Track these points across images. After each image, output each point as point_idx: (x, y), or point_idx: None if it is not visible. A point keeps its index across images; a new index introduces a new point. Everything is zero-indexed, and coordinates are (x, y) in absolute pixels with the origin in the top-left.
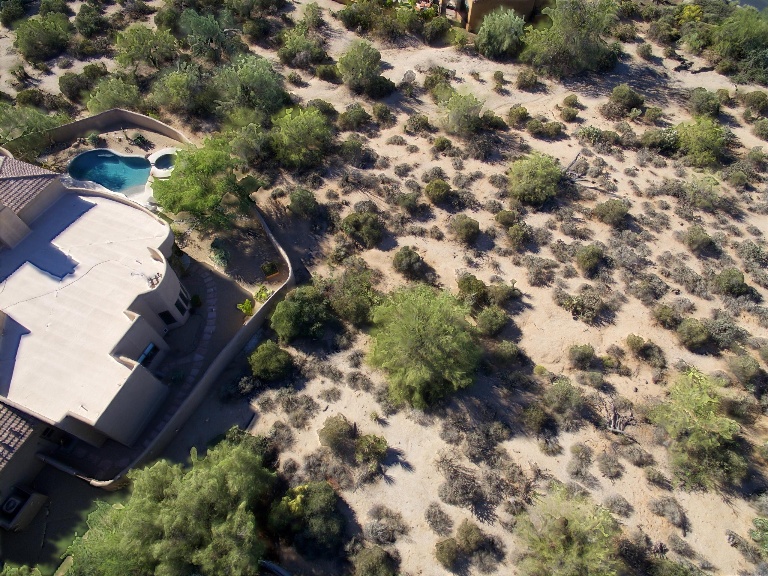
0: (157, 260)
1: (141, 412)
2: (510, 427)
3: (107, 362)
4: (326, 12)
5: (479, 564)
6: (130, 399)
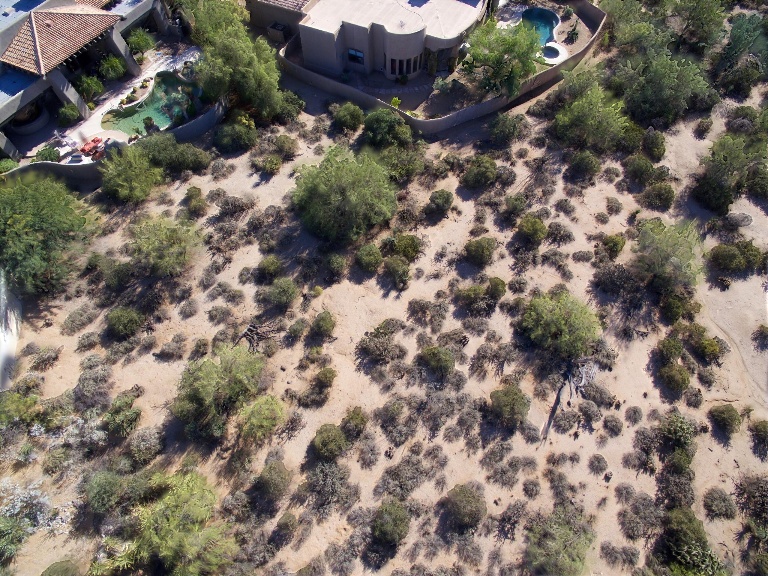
0: None
1: (319, 59)
2: (270, 253)
3: None
4: None
5: (181, 209)
6: (320, 43)
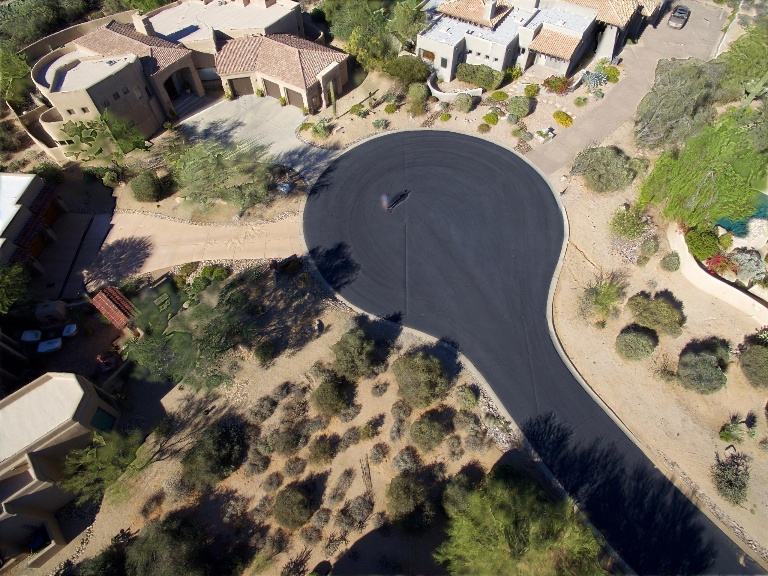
0: (208, 3)
1: None
2: None
3: (266, 10)
4: None
5: None
6: None
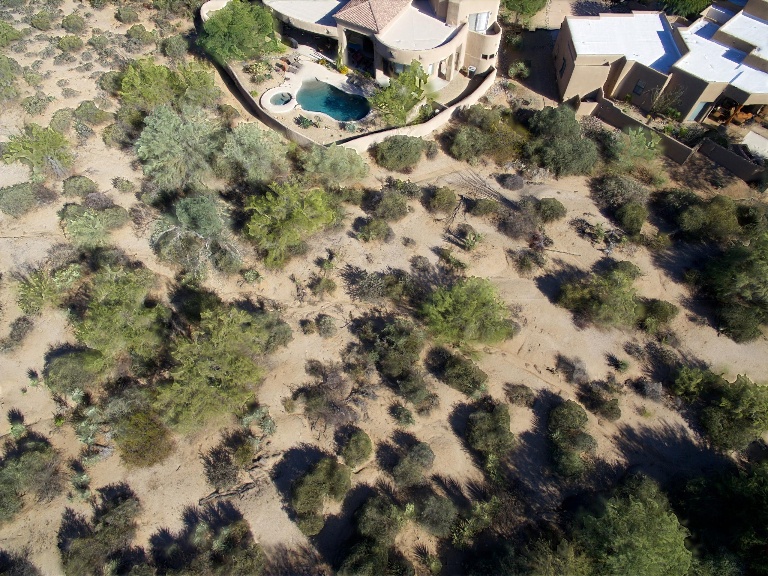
0: None
1: None
2: None
3: None
4: (4, 331)
5: None
6: None
